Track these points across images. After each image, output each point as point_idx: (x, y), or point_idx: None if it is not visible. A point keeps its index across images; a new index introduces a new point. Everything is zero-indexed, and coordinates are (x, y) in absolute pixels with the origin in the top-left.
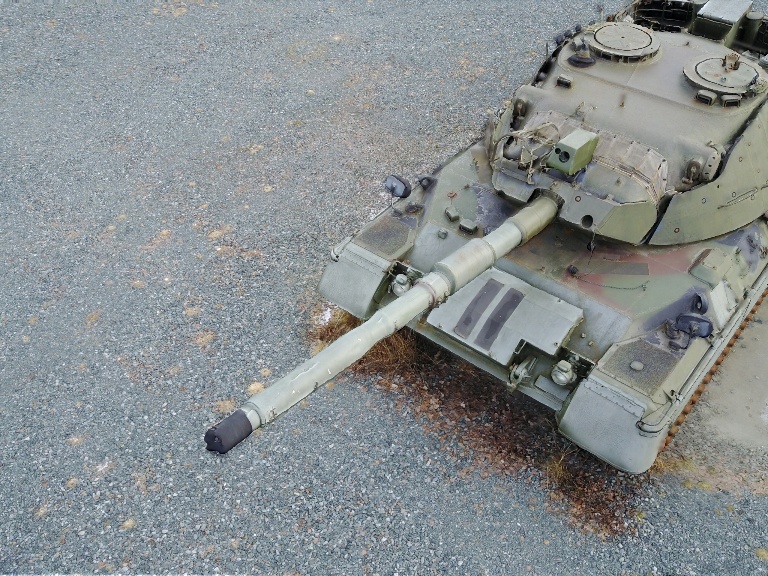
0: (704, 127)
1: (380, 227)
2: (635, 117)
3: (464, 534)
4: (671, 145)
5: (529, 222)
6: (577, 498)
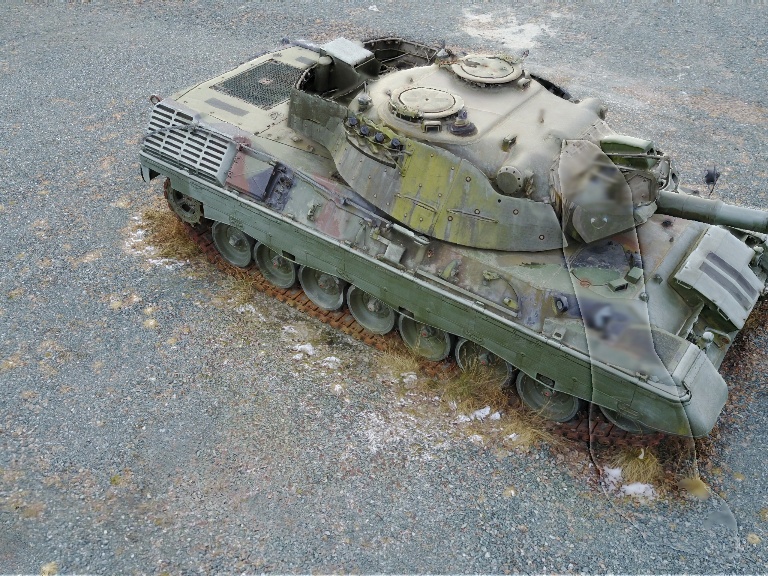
0: (558, 97)
1: None
2: (558, 120)
3: None
4: (592, 113)
5: None
6: (764, 318)
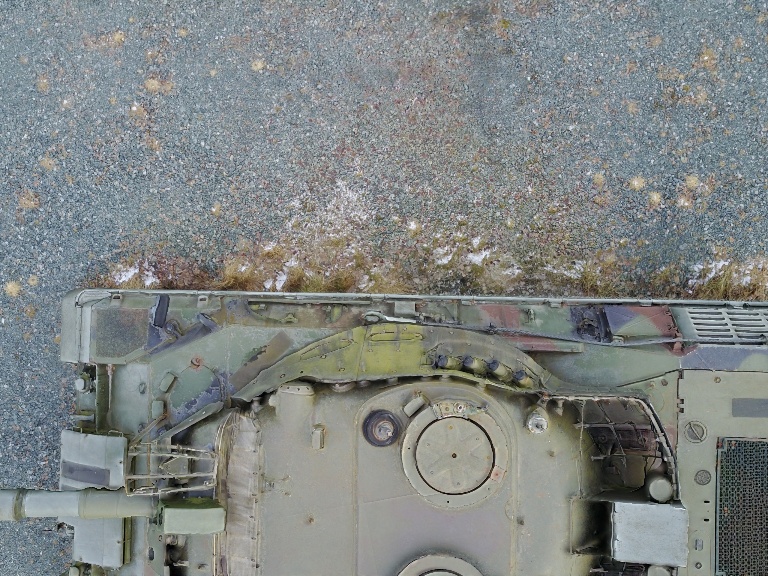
0: None
1: (126, 318)
2: (299, 543)
3: (6, 524)
4: None
5: (100, 513)
6: None
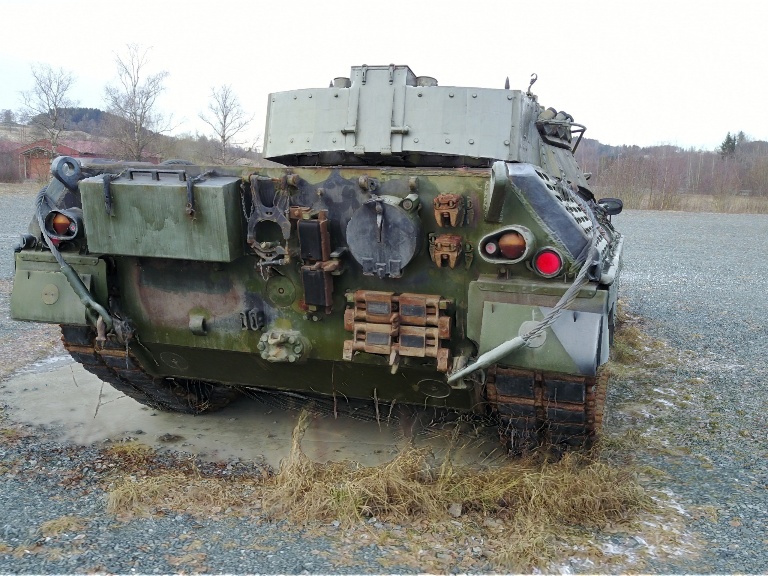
0: None
1: None
2: None
3: None
4: None
5: None
6: None
